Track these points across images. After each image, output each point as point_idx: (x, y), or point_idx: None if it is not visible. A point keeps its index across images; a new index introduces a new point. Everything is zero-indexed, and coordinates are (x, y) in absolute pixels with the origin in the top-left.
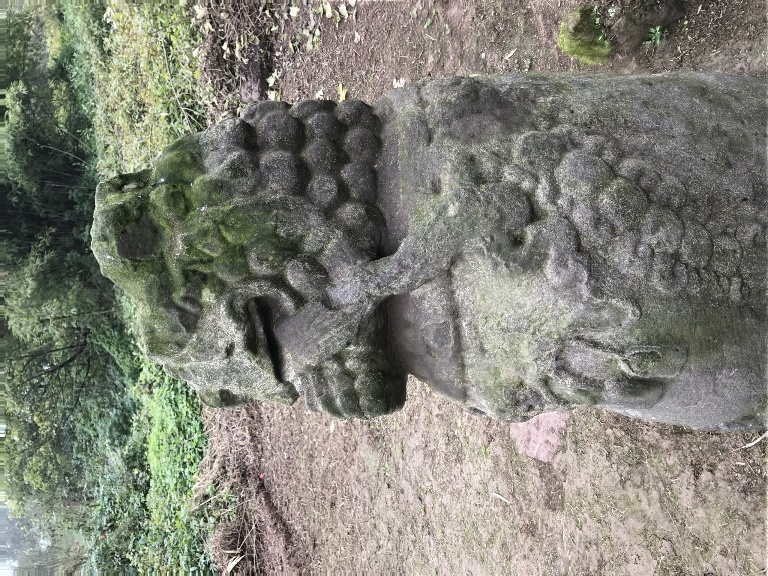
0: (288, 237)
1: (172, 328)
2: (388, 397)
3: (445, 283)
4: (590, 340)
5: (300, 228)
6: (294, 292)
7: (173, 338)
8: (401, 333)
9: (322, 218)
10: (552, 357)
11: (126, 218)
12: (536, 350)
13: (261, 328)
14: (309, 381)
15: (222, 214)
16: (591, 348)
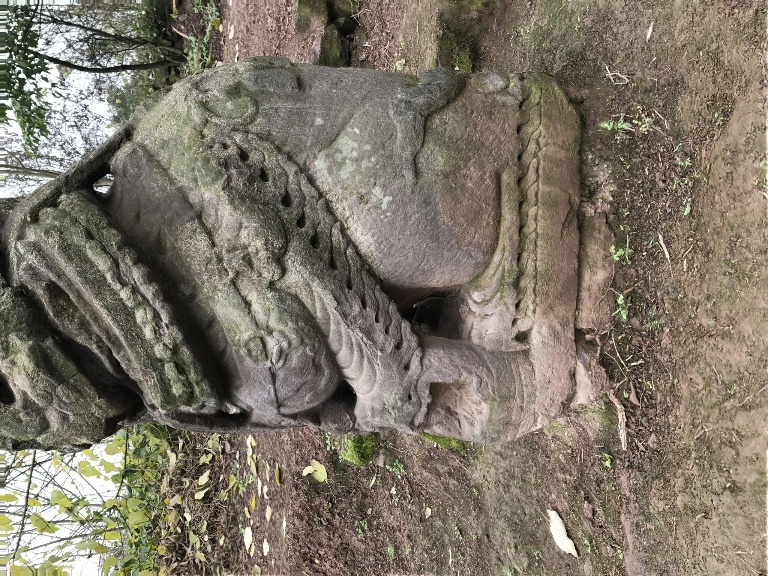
0: None
1: None
2: None
3: (127, 142)
4: None
5: None
6: None
7: None
8: (123, 212)
9: None
10: None
11: None
12: (182, 96)
13: None
14: None
15: None
16: (211, 72)
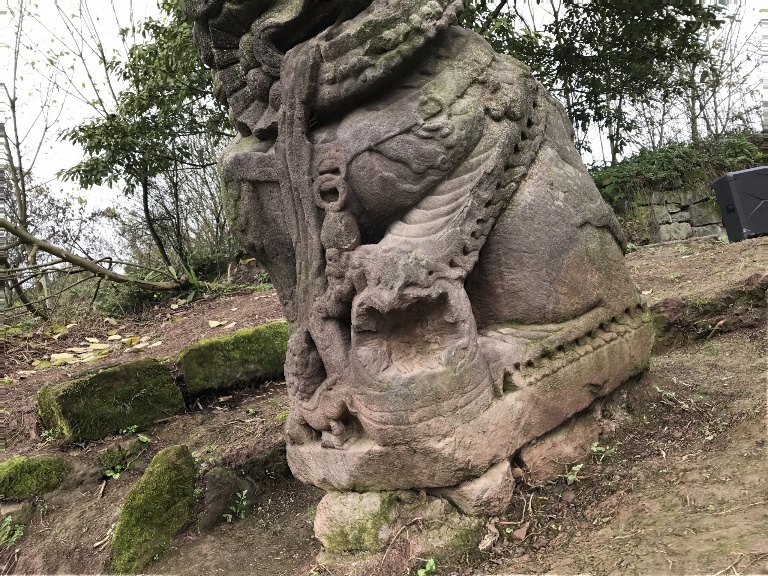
0: None
1: None
2: None
3: None
4: None
5: None
6: None
7: None
8: None
9: None
10: None
11: None
12: None
13: None
14: None
15: None
16: None
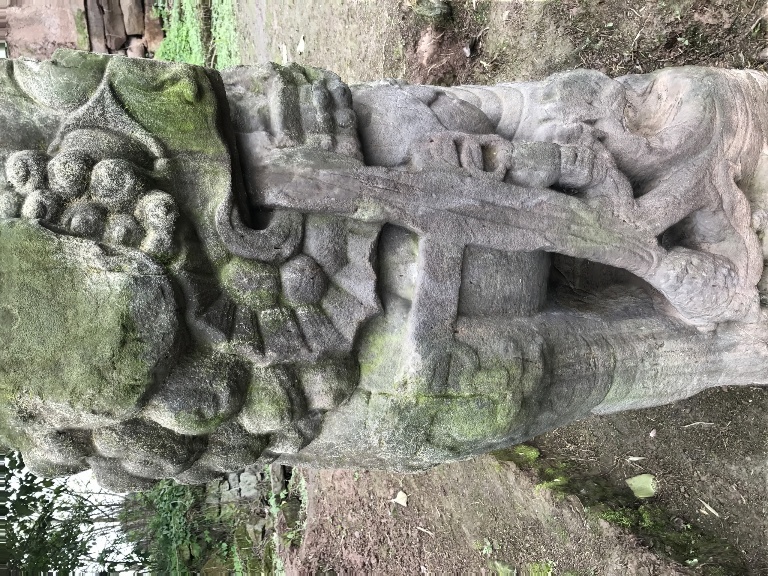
0: None
1: None
2: None
3: None
4: None
5: None
6: None
7: None
8: None
9: None
10: None
11: None
12: None
13: None
14: None
15: None
16: None
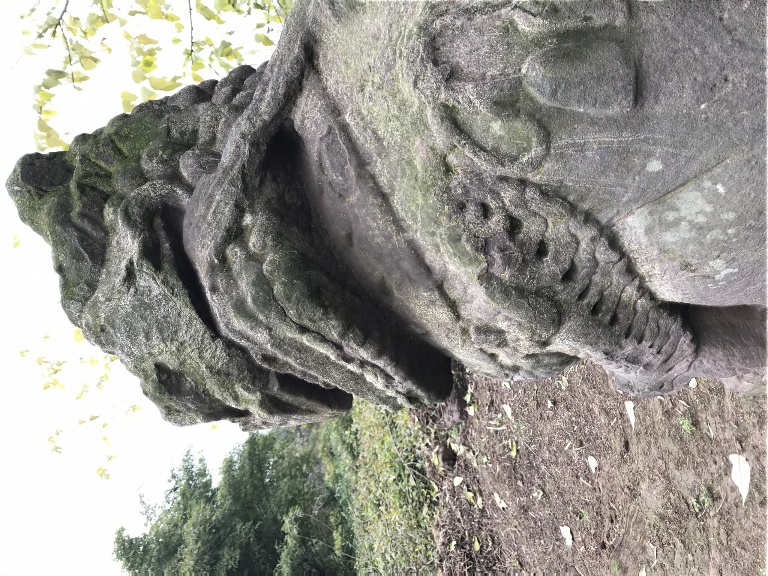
0: (182, 138)
1: (73, 256)
2: (313, 283)
3: (313, 83)
4: (457, 10)
5: (191, 123)
6: (192, 189)
7: (82, 278)
8: (326, 214)
9: (208, 104)
10: (427, 63)
11: (37, 157)
12: (407, 69)
13: (167, 244)
14: (224, 296)
15: (115, 127)
16: (461, 16)
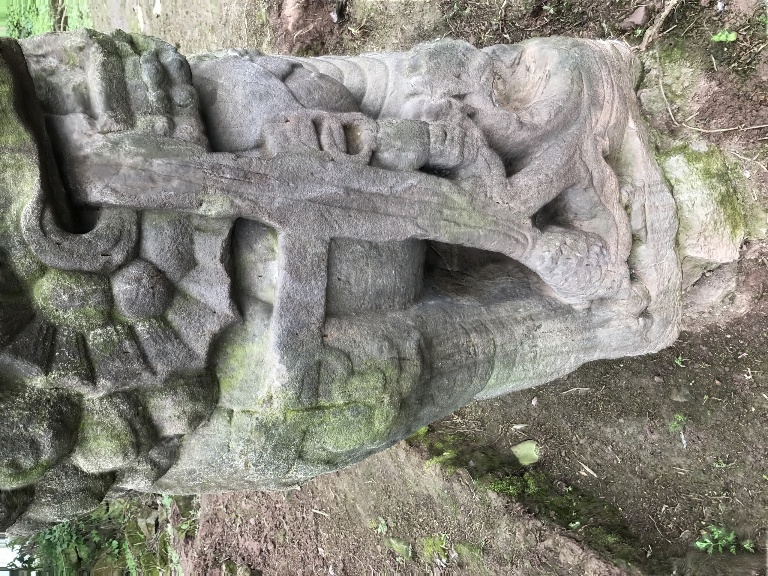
0: None
1: None
2: None
3: None
4: None
5: None
6: None
7: None
8: None
9: None
10: None
11: None
12: None
13: None
14: None
15: None
16: None
